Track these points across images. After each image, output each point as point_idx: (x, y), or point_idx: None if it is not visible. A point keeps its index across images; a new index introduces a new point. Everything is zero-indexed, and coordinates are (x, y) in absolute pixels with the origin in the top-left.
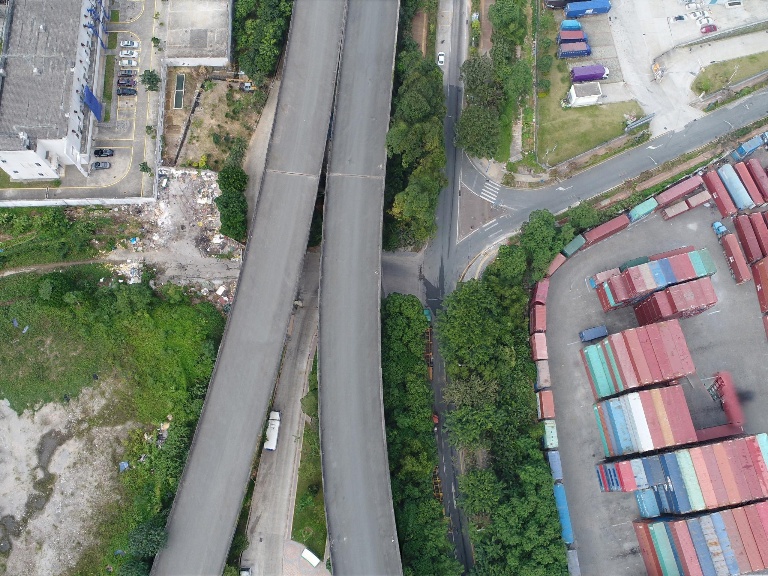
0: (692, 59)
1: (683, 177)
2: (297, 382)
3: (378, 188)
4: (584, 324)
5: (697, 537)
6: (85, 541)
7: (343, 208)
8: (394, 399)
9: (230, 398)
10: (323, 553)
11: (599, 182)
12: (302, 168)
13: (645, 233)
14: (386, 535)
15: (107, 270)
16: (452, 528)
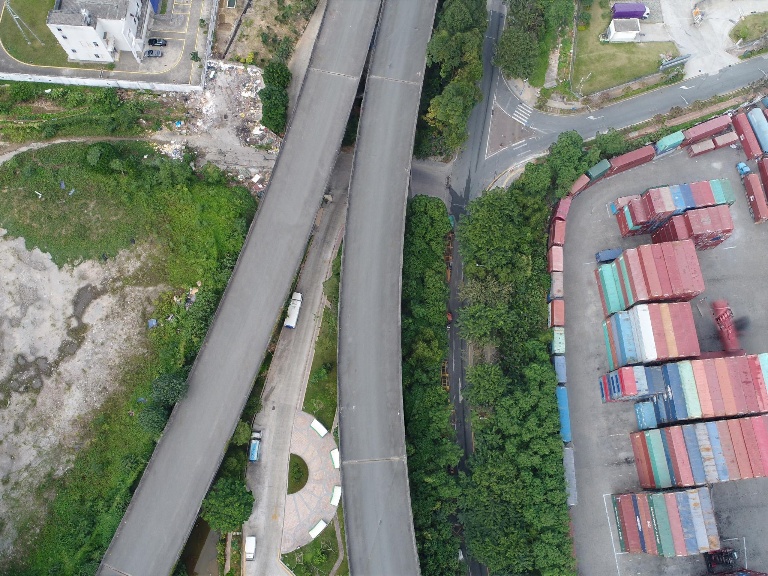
0: (733, 7)
1: (712, 117)
2: (321, 270)
3: (415, 93)
4: (601, 246)
5: (691, 442)
6: (111, 387)
7: (380, 108)
8: (412, 290)
9: (257, 272)
10: (331, 426)
11: (629, 115)
12: (344, 69)
13: (670, 167)
14: (393, 408)
15: (151, 148)
16: (455, 420)
